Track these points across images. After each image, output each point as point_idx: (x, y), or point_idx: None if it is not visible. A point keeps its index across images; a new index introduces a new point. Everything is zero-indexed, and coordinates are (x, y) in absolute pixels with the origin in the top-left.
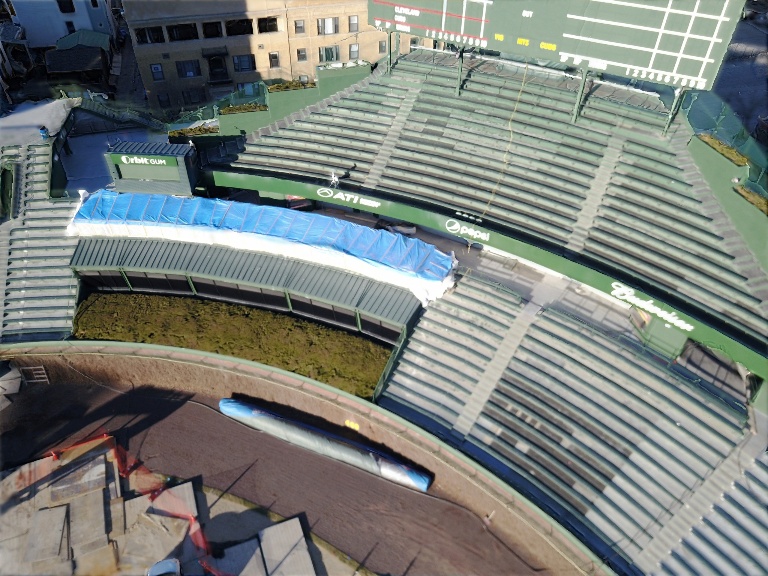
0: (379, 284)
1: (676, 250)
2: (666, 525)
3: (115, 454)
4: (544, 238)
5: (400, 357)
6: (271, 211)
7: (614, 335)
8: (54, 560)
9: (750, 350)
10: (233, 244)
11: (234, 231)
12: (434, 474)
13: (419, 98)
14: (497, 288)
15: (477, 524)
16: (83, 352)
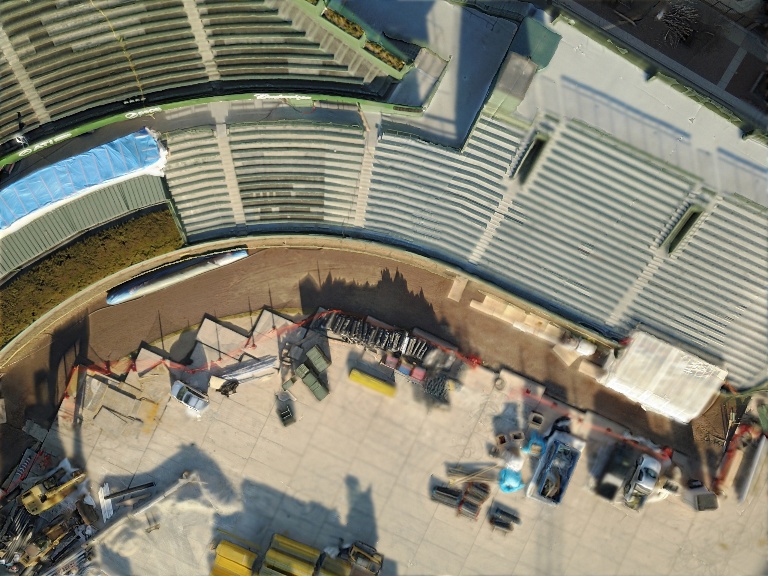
0: (125, 183)
1: (272, 47)
2: (357, 201)
3: (92, 371)
4: (192, 84)
5: (177, 211)
6: (7, 194)
7: (275, 113)
8: (128, 426)
9: (343, 98)
10: (10, 231)
11: (5, 229)
12: (245, 244)
13: (2, 23)
14: (192, 133)
15: (282, 250)
16: (8, 351)
